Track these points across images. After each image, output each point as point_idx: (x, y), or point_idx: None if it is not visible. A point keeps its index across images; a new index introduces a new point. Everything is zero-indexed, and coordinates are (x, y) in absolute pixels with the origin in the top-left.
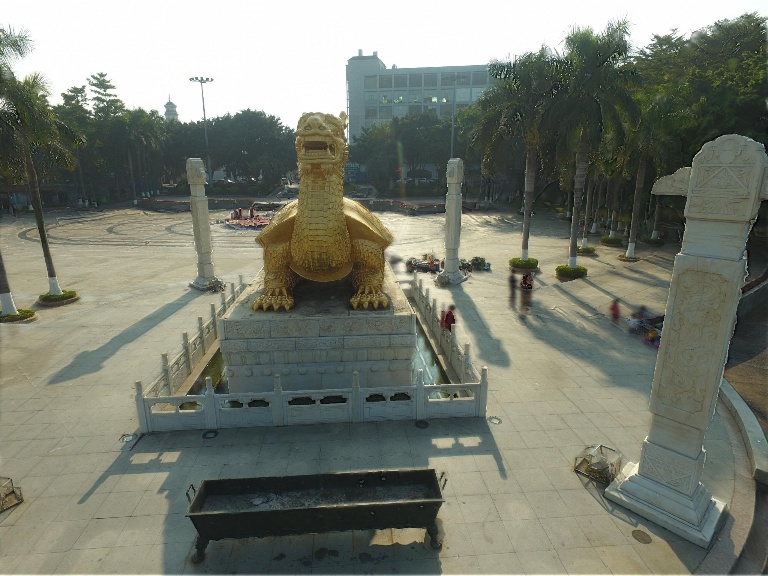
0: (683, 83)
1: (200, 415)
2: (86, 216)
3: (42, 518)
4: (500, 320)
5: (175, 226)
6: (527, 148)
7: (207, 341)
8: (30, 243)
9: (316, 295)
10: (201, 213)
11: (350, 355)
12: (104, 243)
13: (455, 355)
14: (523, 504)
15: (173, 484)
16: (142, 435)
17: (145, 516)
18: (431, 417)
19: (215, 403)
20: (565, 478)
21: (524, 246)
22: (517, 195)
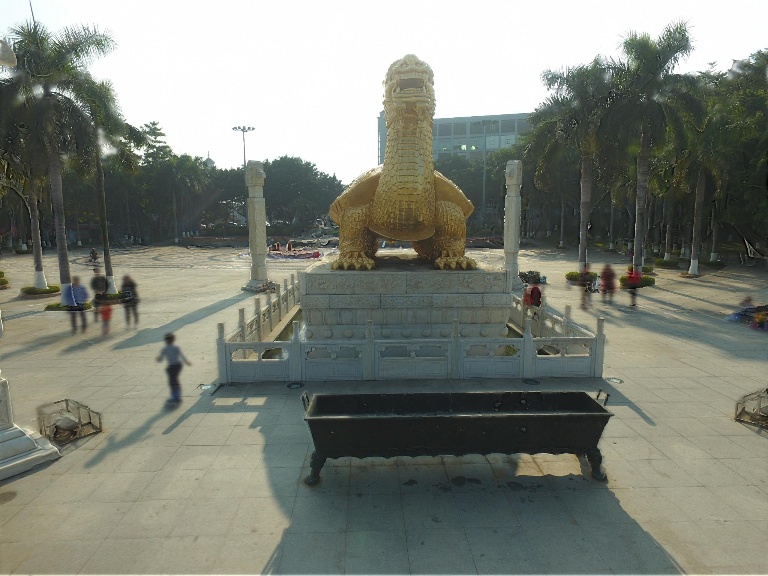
0: (734, 102)
1: (284, 364)
2: (131, 249)
3: (125, 444)
4: (578, 312)
5: (216, 256)
6: (582, 158)
7: (273, 319)
8: (81, 266)
9: (393, 264)
10: (258, 214)
11: (439, 316)
12: (151, 266)
13: (548, 327)
14: (689, 446)
15: (265, 421)
16: (221, 385)
17: (240, 445)
18: (539, 376)
19: (301, 351)
20: (728, 426)
21: (582, 258)
22: (555, 230)
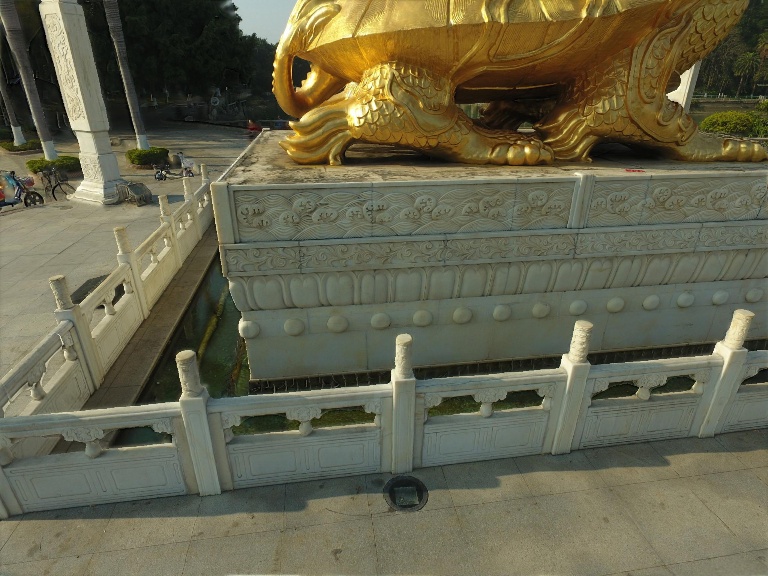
0: None
1: None
2: None
3: None
4: None
5: None
6: None
7: None
8: None
9: None
10: None
11: None
12: None
13: None
14: None
15: None
16: None
17: None
18: None
19: None
20: None
21: (47, 135)
22: None
